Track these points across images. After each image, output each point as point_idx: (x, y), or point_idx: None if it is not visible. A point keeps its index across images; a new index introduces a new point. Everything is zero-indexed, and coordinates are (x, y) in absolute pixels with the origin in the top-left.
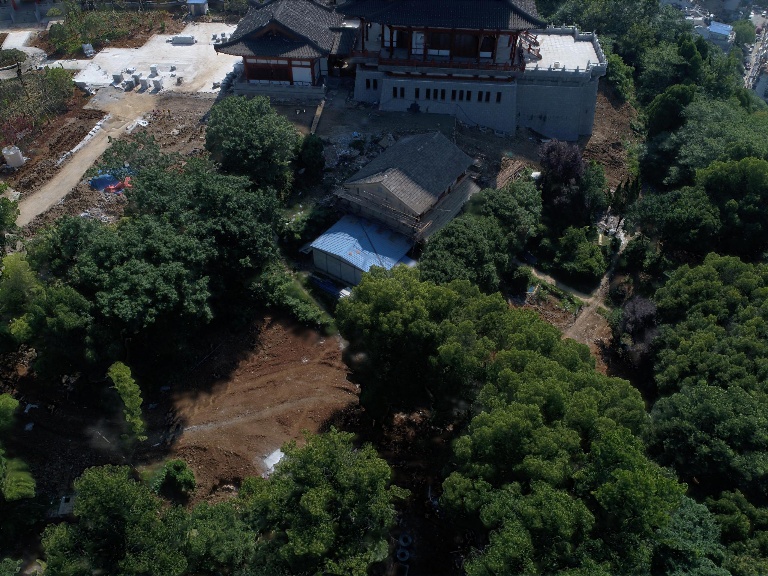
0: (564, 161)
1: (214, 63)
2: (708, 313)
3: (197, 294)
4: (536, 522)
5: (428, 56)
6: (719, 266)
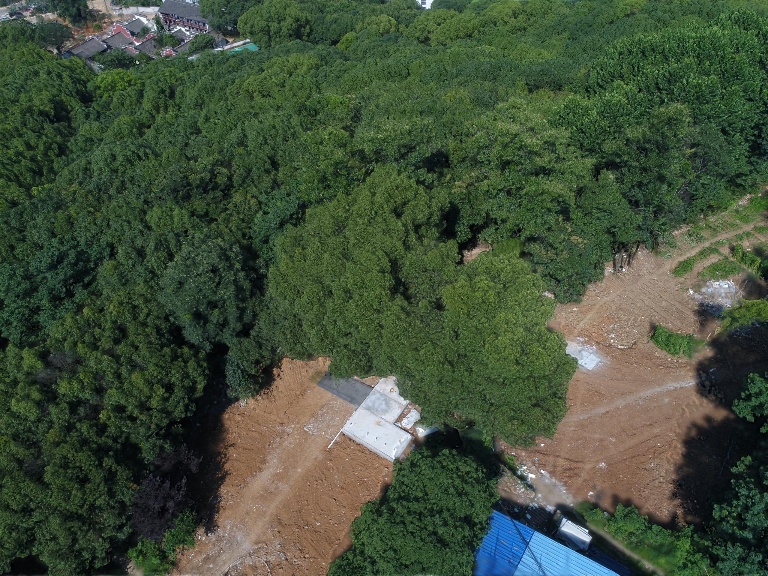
0: None
1: None
2: (101, 429)
3: (764, 387)
4: (402, 126)
5: None
6: None
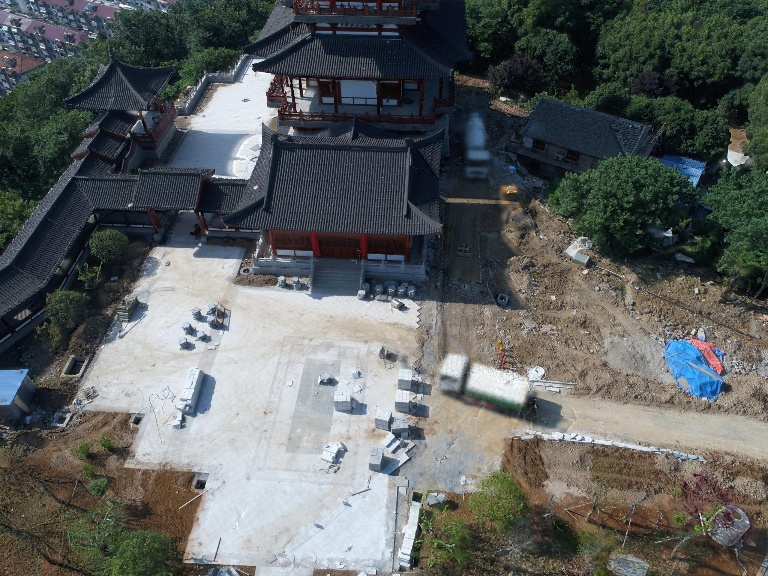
0: (526, 67)
1: (305, 325)
2: None
3: None
4: None
5: (424, 80)
6: (640, 31)
